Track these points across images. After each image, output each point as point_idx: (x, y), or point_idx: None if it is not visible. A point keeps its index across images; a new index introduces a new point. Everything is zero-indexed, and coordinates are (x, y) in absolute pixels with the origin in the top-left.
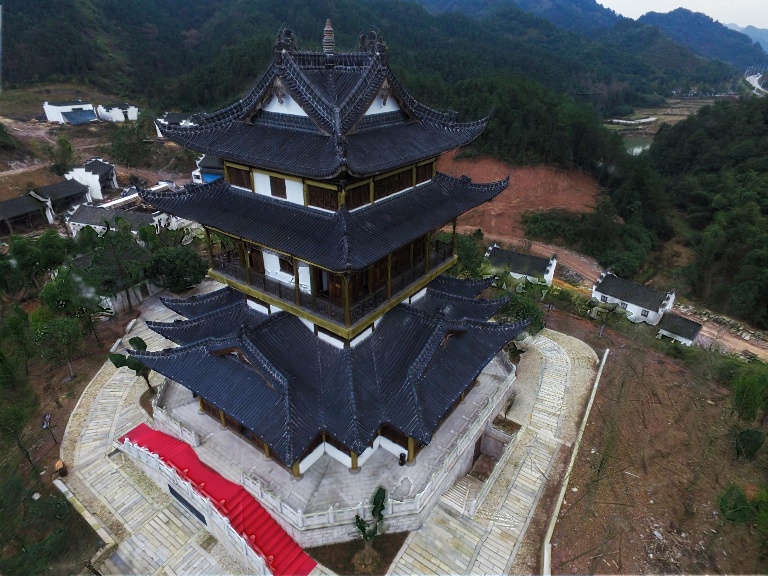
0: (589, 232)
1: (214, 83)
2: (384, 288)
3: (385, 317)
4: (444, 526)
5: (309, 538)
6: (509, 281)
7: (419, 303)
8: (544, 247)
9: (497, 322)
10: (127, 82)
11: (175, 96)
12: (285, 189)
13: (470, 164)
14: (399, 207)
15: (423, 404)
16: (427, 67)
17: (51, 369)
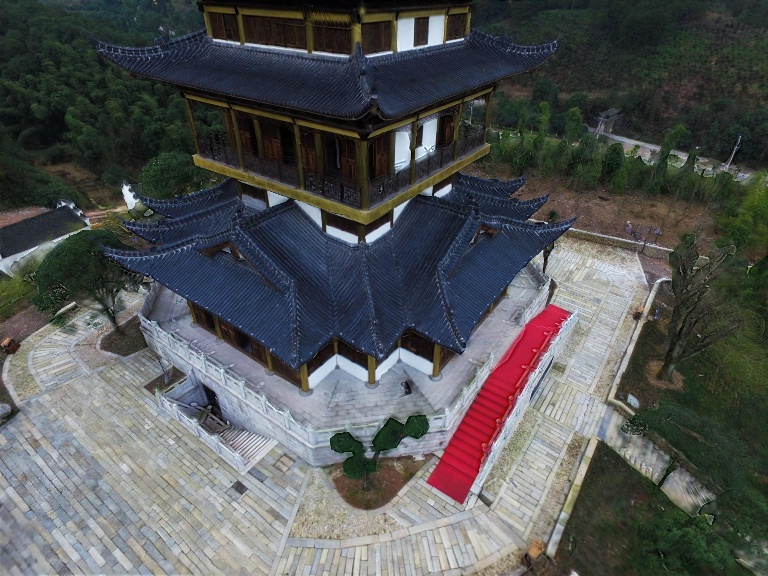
0: (1, 181)
1: None
2: None
3: None
4: None
5: None
6: None
7: None
8: None
9: None
10: None
11: None
12: (426, 31)
13: None
14: None
15: None
16: None
17: None
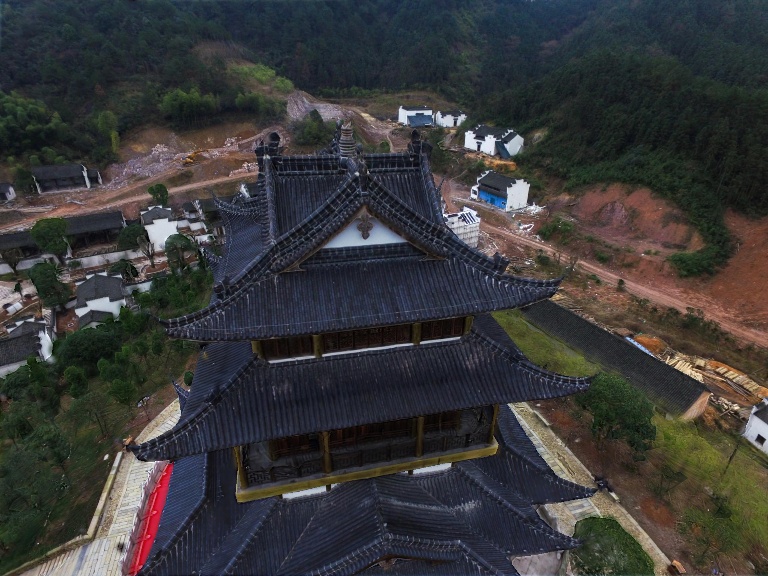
0: None
1: (535, 99)
2: None
3: None
4: None
5: None
6: (726, 476)
7: (431, 477)
8: None
9: None
10: (471, 91)
11: (495, 110)
12: None
13: None
14: (361, 370)
15: None
16: None
17: None
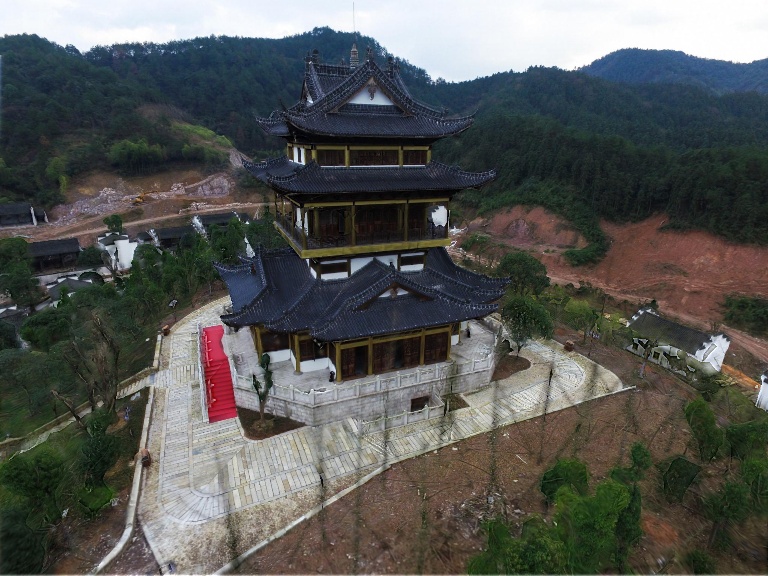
0: None
1: (447, 151)
2: (349, 234)
3: (364, 269)
4: (333, 432)
5: (240, 397)
6: (601, 324)
7: (412, 275)
8: (747, 338)
9: (464, 299)
10: None
11: None
12: None
13: (677, 236)
14: (372, 174)
15: (343, 324)
16: (678, 144)
17: (207, 292)
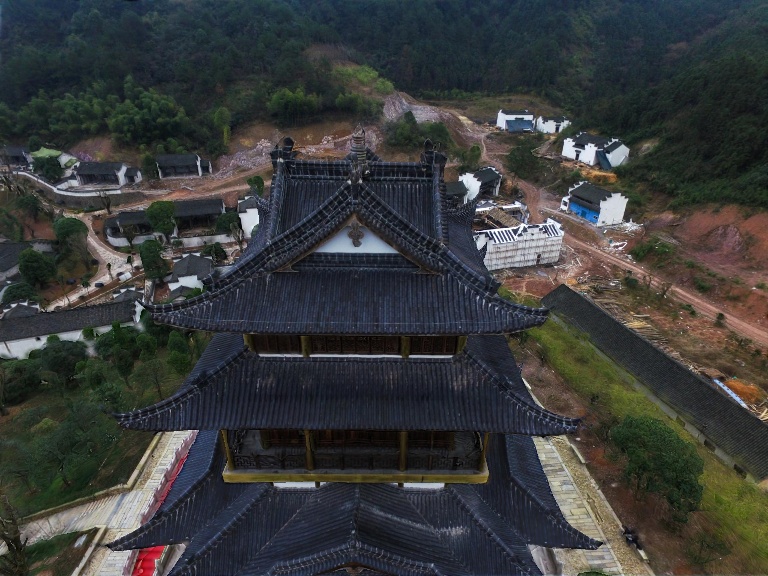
0: None
1: (648, 107)
2: None
3: None
4: None
5: None
6: None
7: (423, 494)
8: None
9: None
10: (579, 96)
11: (600, 117)
12: None
13: None
14: (345, 375)
15: None
16: None
17: None
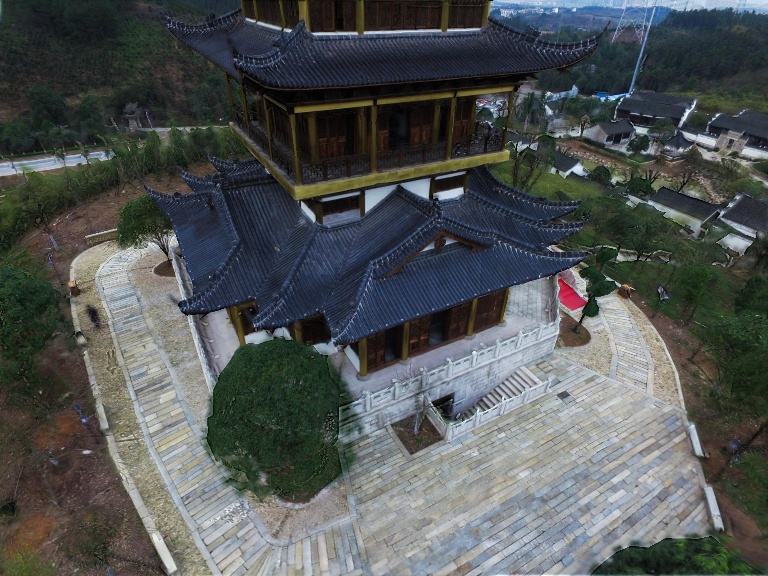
0: None
1: None
2: None
3: None
4: None
5: None
6: None
7: None
8: None
9: None
10: None
11: None
12: None
13: None
14: None
15: None
16: None
17: None
